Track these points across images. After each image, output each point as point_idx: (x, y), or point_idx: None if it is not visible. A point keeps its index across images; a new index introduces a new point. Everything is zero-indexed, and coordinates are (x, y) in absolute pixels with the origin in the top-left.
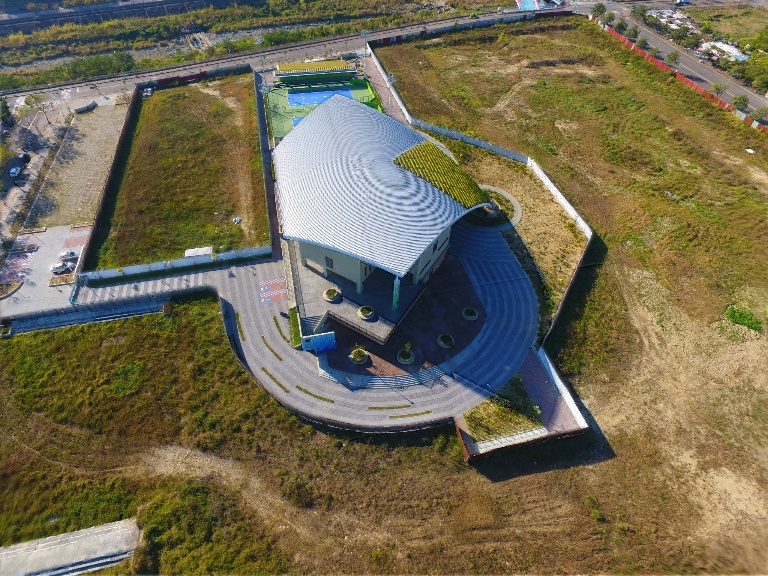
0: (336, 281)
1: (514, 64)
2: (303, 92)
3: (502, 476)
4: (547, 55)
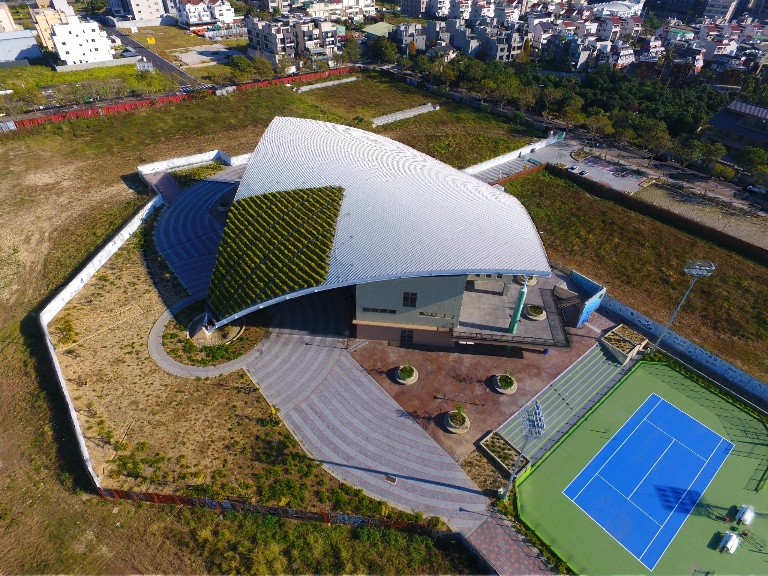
0: None
1: None
2: None
3: None
4: None
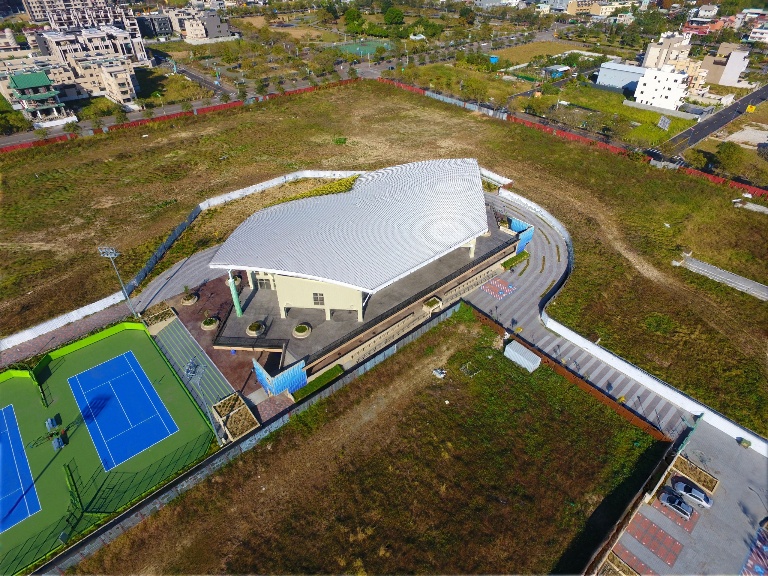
0: None
1: None
2: None
3: None
4: None
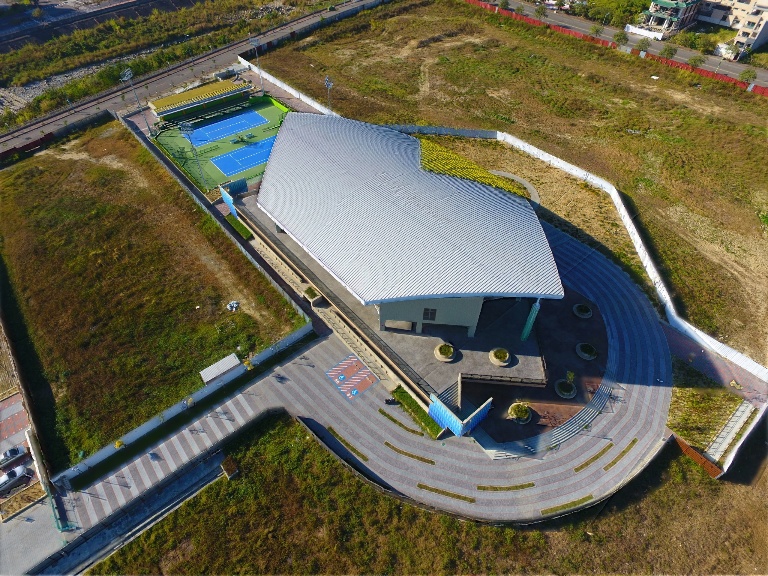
0: (435, 333)
1: (404, 47)
2: (200, 127)
3: (754, 475)
4: (428, 32)
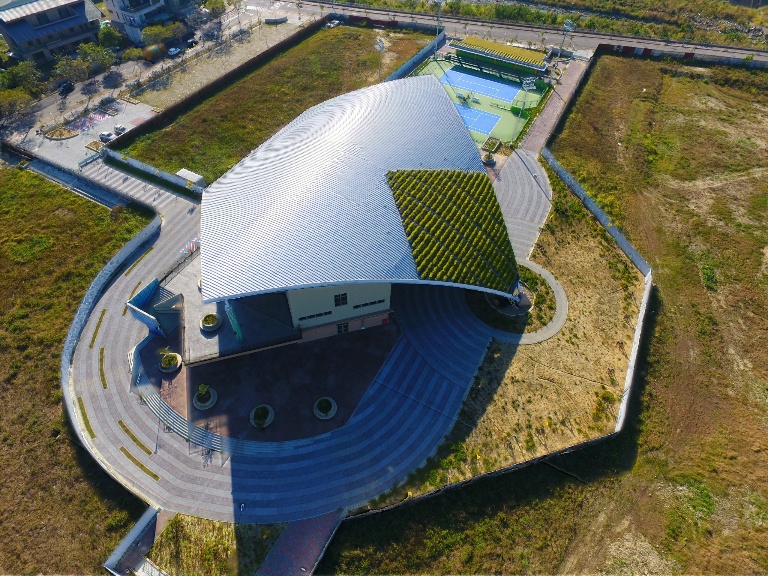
0: None
1: None
2: (467, 73)
3: None
4: None
